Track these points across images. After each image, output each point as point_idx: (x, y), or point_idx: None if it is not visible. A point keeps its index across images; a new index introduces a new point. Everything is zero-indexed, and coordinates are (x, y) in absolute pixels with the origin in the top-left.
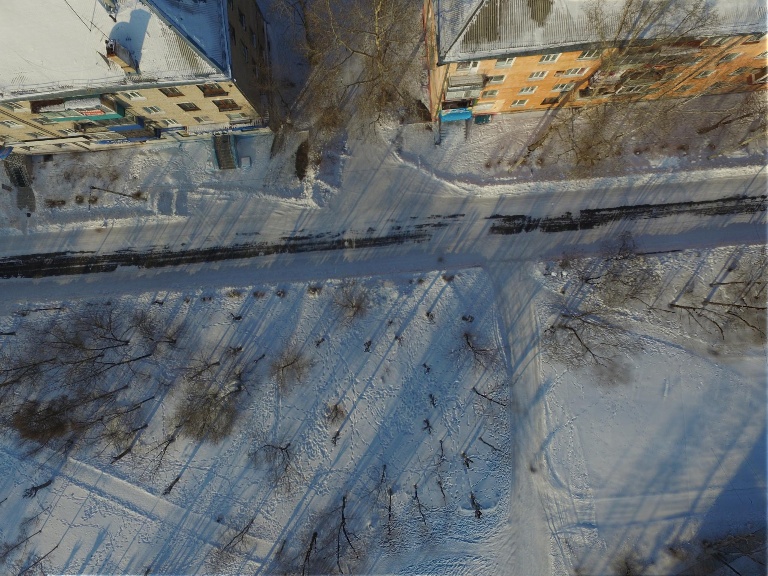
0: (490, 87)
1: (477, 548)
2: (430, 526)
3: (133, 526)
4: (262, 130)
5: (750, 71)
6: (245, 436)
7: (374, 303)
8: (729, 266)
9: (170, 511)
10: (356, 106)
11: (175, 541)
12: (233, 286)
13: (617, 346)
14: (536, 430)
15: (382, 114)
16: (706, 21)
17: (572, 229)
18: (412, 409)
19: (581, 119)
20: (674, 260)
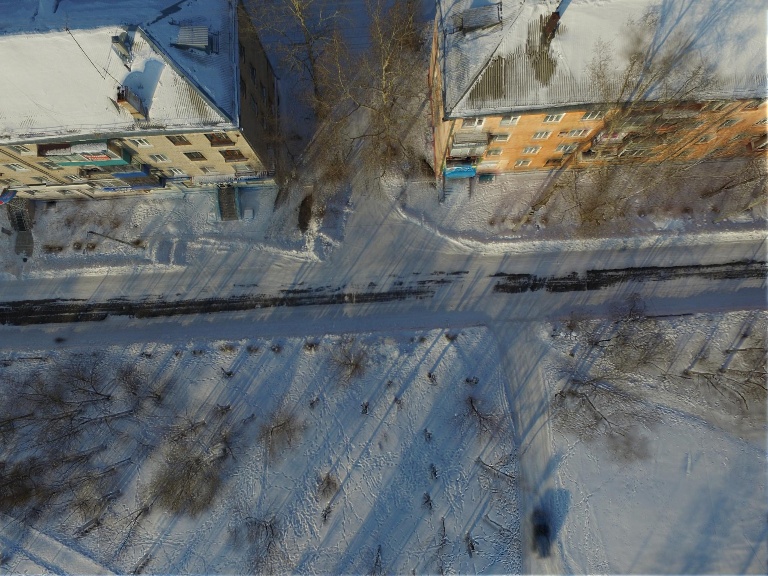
0: (494, 146)
1: None
2: None
3: None
4: (267, 183)
5: (749, 139)
6: (226, 506)
7: (373, 361)
8: (745, 332)
9: None
10: (361, 164)
11: None
12: (226, 339)
13: (632, 415)
14: (548, 508)
15: (387, 172)
16: (706, 86)
17: (579, 289)
18: (411, 480)
19: (584, 182)
20: (687, 324)
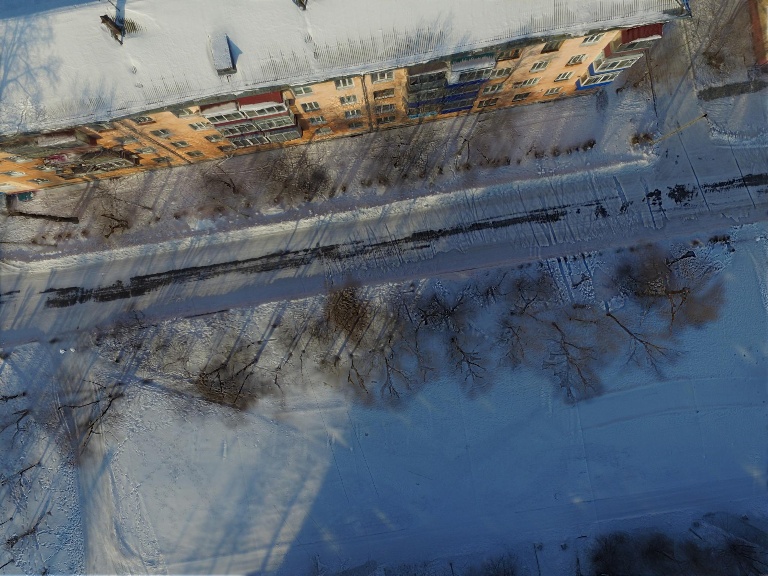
0: None
1: None
2: None
3: None
4: None
5: None
6: None
7: None
8: (274, 322)
9: None
10: None
11: None
12: None
13: (174, 410)
14: (105, 500)
15: None
16: (44, 116)
17: (124, 297)
18: None
19: (122, 188)
20: (220, 321)
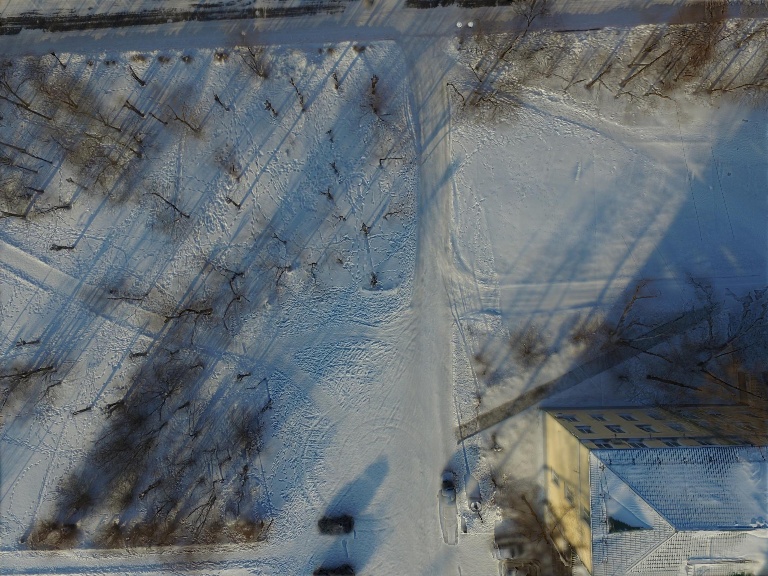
0: None
1: (377, 332)
2: (329, 307)
3: (24, 296)
4: None
5: None
6: (143, 206)
7: (282, 73)
8: None
9: (63, 281)
10: None
11: (67, 313)
12: (138, 50)
13: (530, 126)
14: (443, 212)
15: None
16: None
17: (490, 5)
18: (316, 185)
19: None
20: (592, 38)
